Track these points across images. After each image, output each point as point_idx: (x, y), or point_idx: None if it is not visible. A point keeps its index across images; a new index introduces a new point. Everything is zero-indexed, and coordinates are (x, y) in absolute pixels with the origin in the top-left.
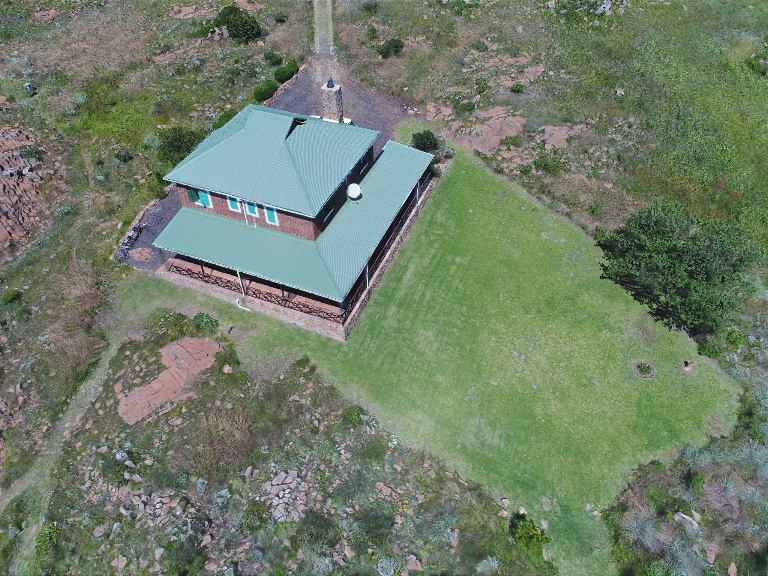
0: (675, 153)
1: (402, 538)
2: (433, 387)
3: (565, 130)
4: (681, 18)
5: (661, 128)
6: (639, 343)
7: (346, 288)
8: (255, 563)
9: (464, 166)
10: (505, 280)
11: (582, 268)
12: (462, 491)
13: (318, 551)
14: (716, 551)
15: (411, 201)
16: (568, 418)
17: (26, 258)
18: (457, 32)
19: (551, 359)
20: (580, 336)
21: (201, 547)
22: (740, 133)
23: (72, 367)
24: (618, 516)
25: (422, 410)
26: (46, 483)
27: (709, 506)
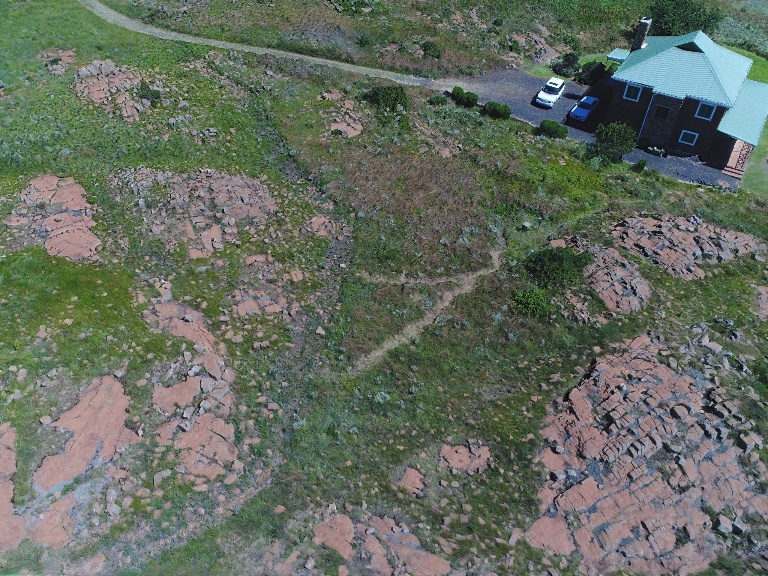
0: (557, 7)
1: None
2: None
3: None
4: None
5: None
6: None
7: (767, 84)
8: None
9: None
10: None
11: None
12: None
13: None
14: None
15: None
16: None
17: (761, 234)
18: None
19: None
20: None
21: None
22: None
23: None
24: None
25: None
26: None
27: None
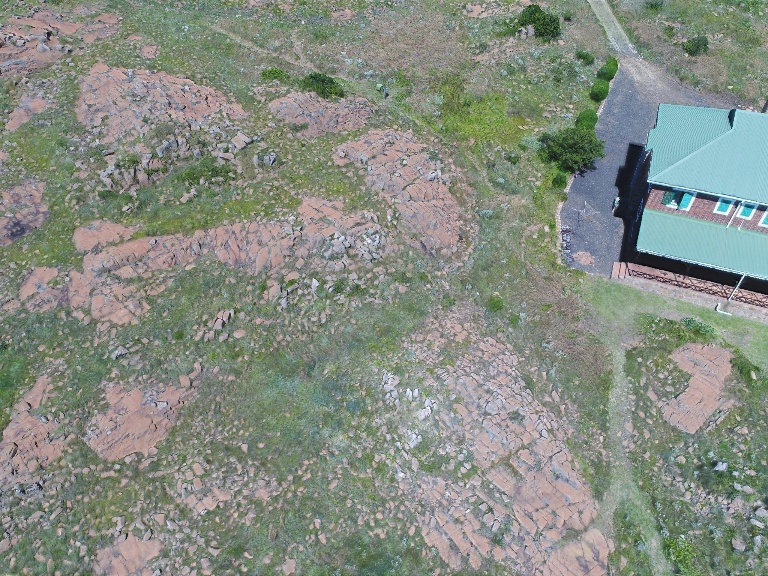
0: None
1: None
2: None
3: None
4: None
5: None
6: None
7: None
8: None
9: None
10: None
11: None
12: None
13: None
14: None
15: None
16: None
17: (478, 263)
18: (755, 29)
19: None
20: None
21: None
22: None
23: (598, 375)
24: None
25: None
26: (637, 495)
27: None
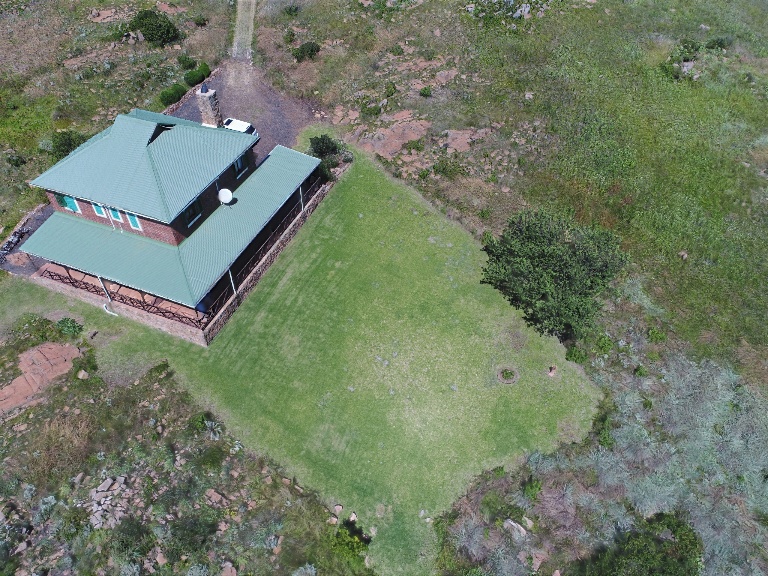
0: (576, 157)
1: (222, 545)
2: (288, 393)
3: (468, 134)
4: (601, 21)
5: (565, 132)
6: (507, 348)
7: (200, 294)
8: (65, 570)
9: (363, 170)
10: (382, 285)
11: (463, 273)
12: (293, 498)
13: (126, 558)
14: (543, 558)
15: (294, 206)
16: (420, 424)
17: None
18: (375, 36)
19: (414, 365)
20: (448, 341)
21: (15, 554)
22: (644, 137)
23: None
24: (448, 523)
25: (272, 416)
26: None
27: (544, 513)
